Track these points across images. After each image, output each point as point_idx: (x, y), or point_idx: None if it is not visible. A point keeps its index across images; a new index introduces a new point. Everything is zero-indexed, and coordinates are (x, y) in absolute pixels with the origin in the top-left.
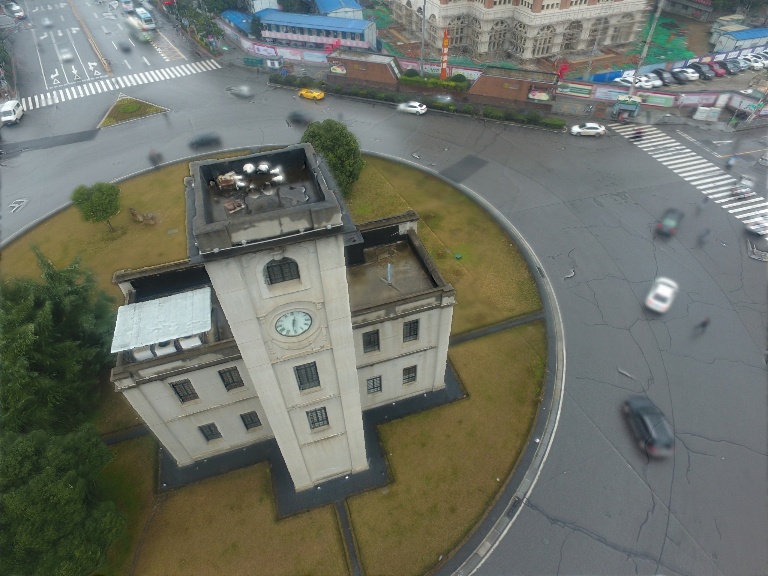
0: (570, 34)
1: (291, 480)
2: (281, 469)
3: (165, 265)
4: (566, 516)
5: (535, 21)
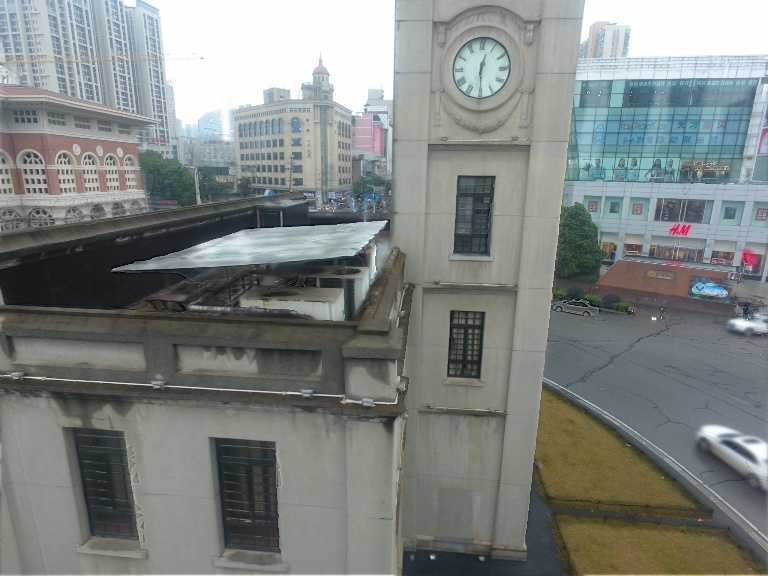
0: (97, 216)
1: (501, 563)
2: (474, 574)
3: (87, 221)
4: (578, 374)
5: (61, 201)
